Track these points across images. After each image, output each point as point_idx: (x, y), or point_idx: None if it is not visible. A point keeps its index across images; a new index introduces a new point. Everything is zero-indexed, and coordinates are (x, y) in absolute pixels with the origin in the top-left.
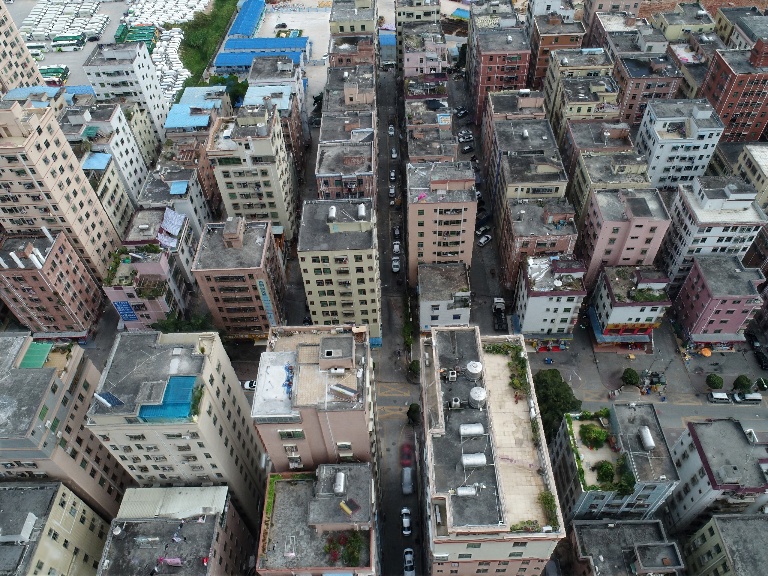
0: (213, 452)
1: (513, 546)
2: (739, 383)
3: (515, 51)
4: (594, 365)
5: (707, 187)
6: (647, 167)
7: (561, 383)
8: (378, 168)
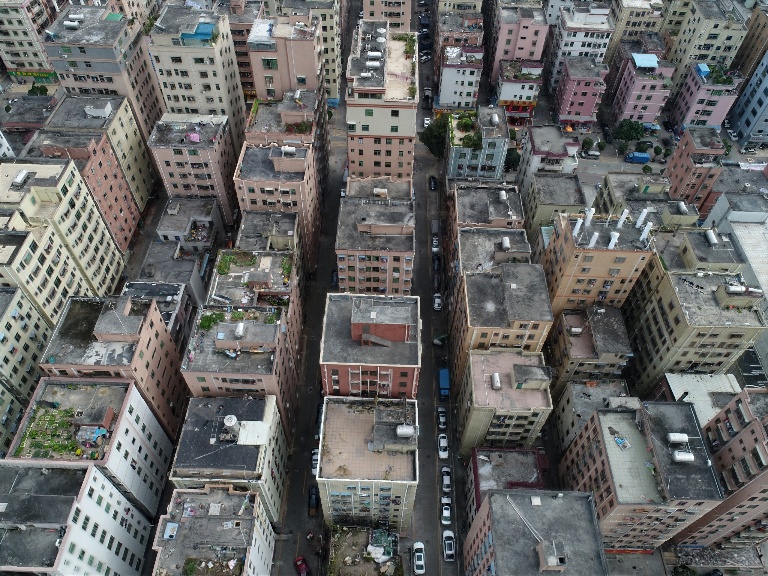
0: (221, 83)
1: (391, 116)
2: (584, 141)
3: None
4: None
5: (578, 6)
6: (548, 6)
7: None
8: (350, 8)
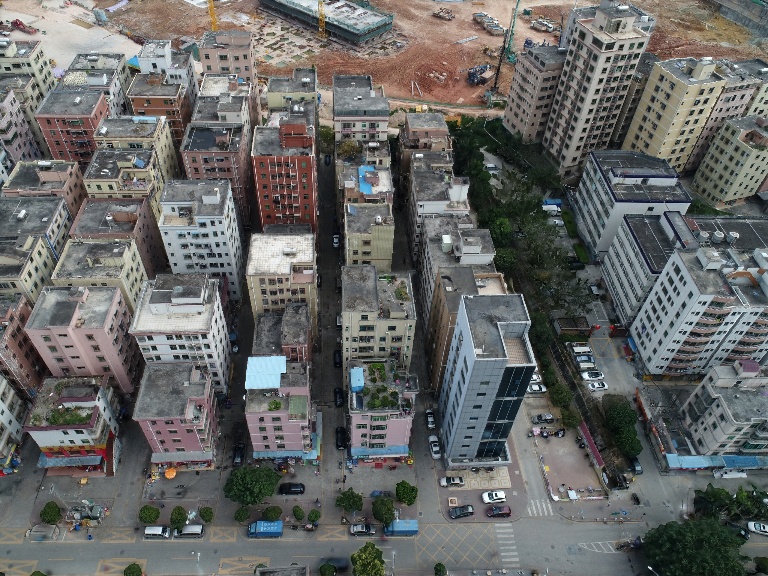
0: None
1: None
2: None
3: (73, 115)
4: (34, 494)
5: (159, 288)
6: None
7: None
8: None
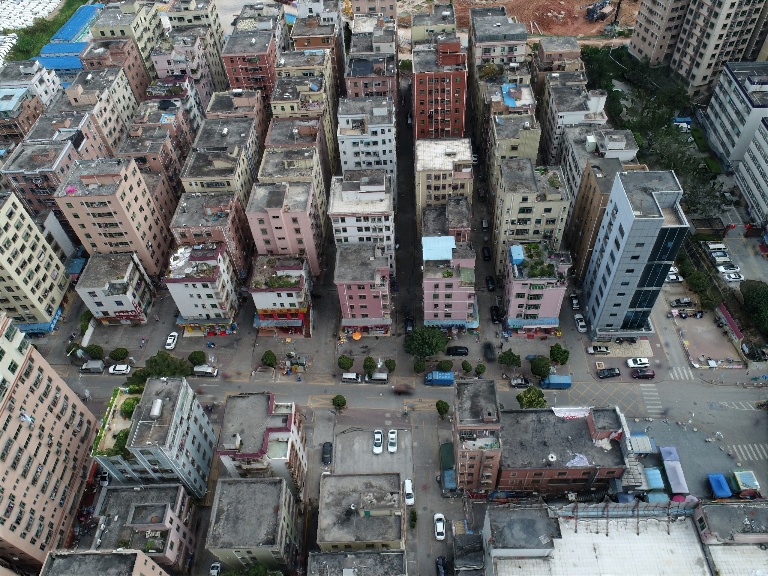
0: None
1: None
2: None
3: (252, 53)
4: (251, 348)
5: (348, 180)
6: None
7: (174, 363)
8: None
